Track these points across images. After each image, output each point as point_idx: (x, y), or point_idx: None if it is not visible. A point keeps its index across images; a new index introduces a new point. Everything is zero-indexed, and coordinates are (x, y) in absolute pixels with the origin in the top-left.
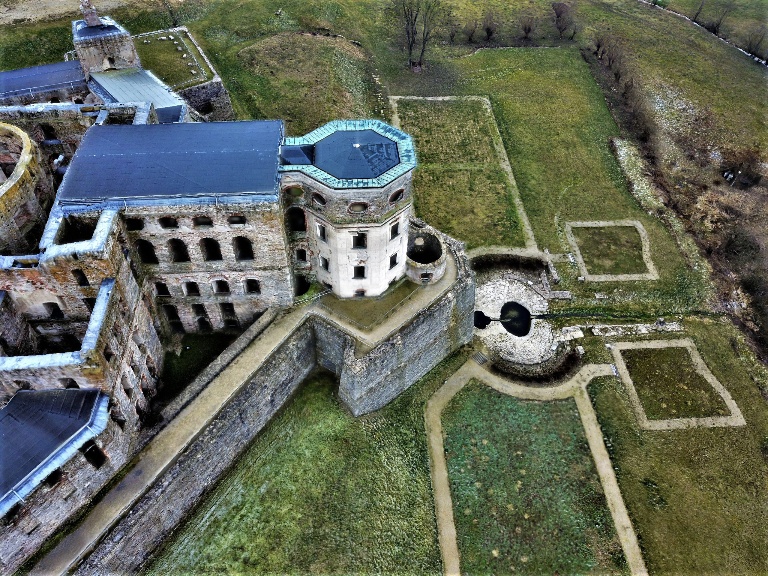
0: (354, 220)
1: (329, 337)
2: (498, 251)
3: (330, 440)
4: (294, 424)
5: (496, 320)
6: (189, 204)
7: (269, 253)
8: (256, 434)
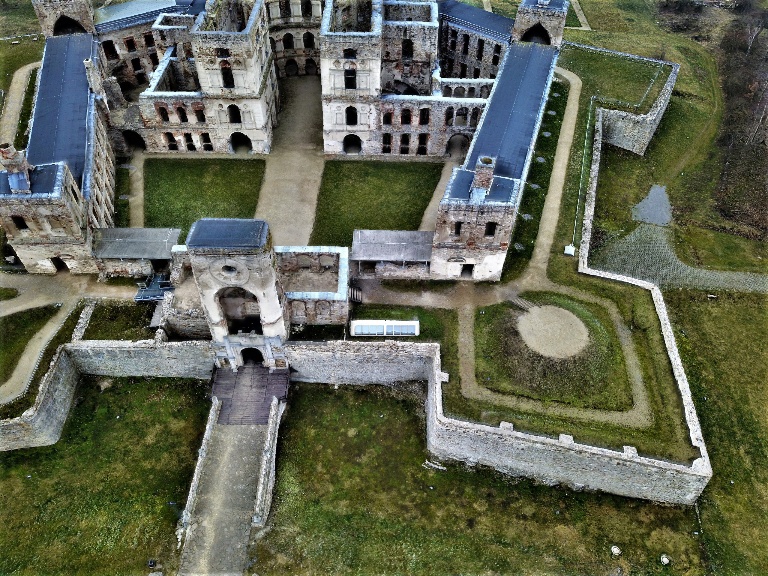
0: None
1: None
2: None
3: None
4: None
5: None
6: None
7: None
8: None
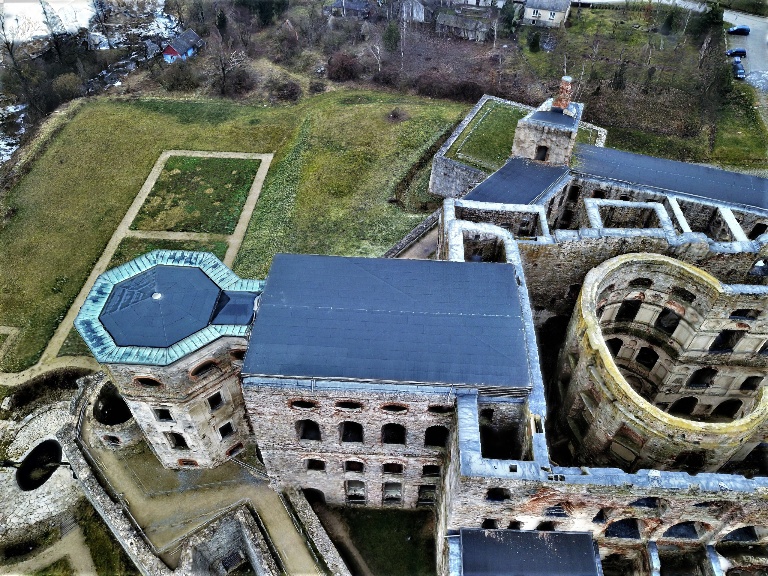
0: None
1: None
2: None
3: None
4: None
5: (65, 464)
6: None
7: None
8: None
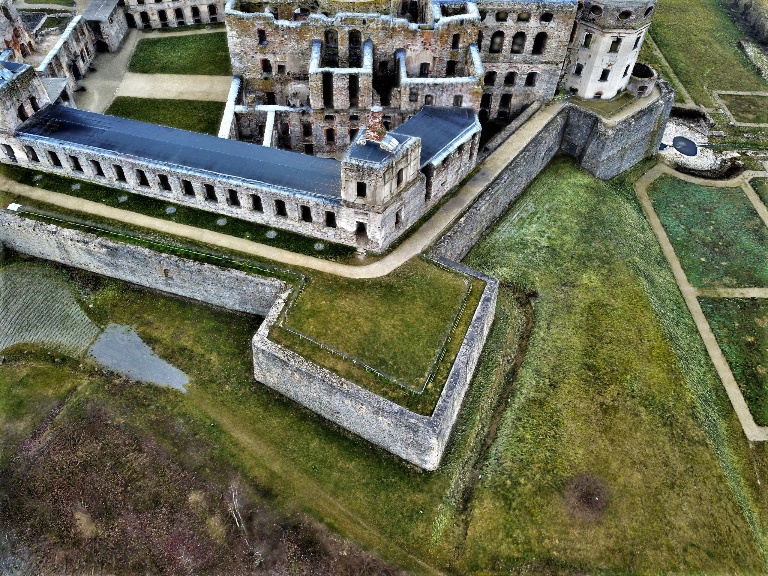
0: (619, 26)
1: (581, 120)
2: None
3: (583, 187)
4: (555, 178)
5: (670, 146)
6: (522, 1)
7: (556, 49)
8: (532, 180)
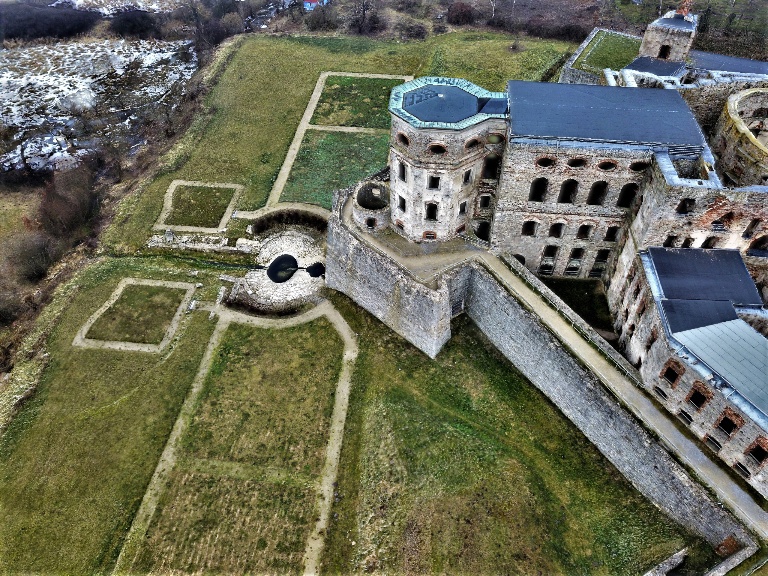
0: None
1: None
2: (264, 321)
3: None
4: None
5: (301, 268)
6: None
7: None
8: None
